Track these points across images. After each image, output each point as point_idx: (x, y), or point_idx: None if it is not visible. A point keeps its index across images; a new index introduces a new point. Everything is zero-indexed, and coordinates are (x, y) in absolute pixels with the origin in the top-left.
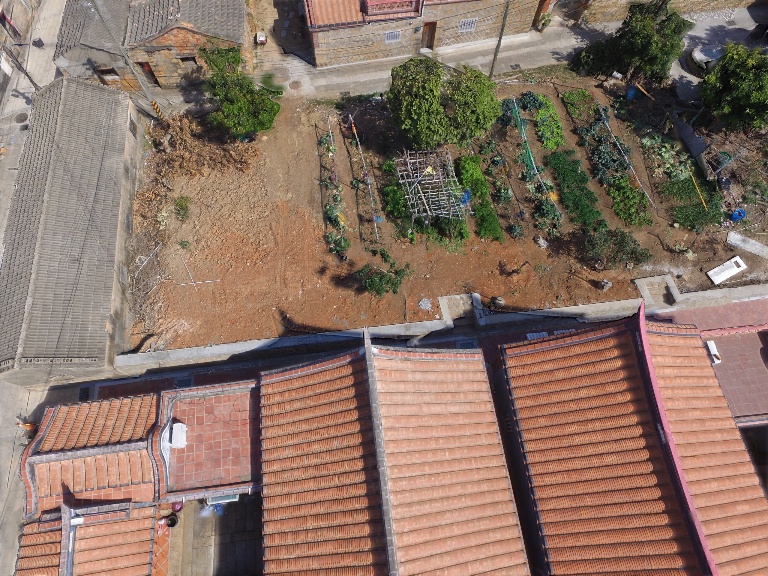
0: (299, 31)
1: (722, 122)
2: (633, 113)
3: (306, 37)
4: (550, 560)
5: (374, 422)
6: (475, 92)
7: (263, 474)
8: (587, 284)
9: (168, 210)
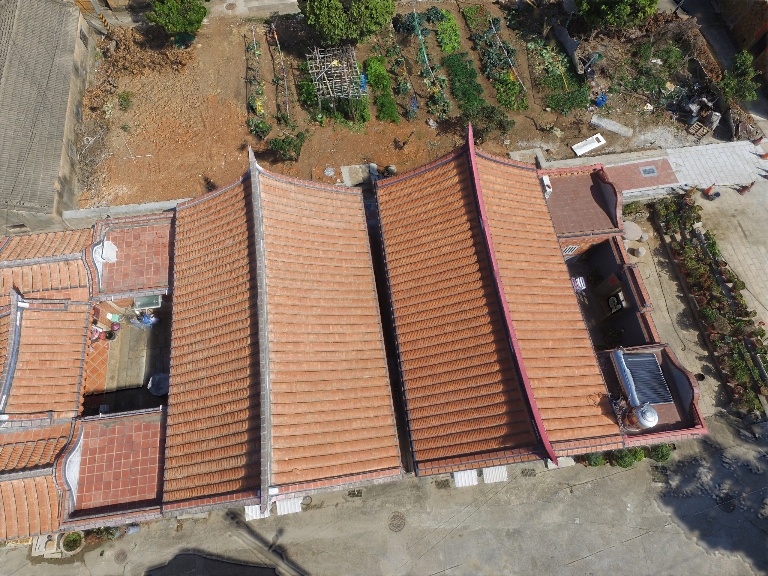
0: None
1: (588, 21)
2: (523, 23)
3: None
4: (397, 325)
5: (254, 215)
6: None
7: (174, 272)
8: None
9: (113, 102)
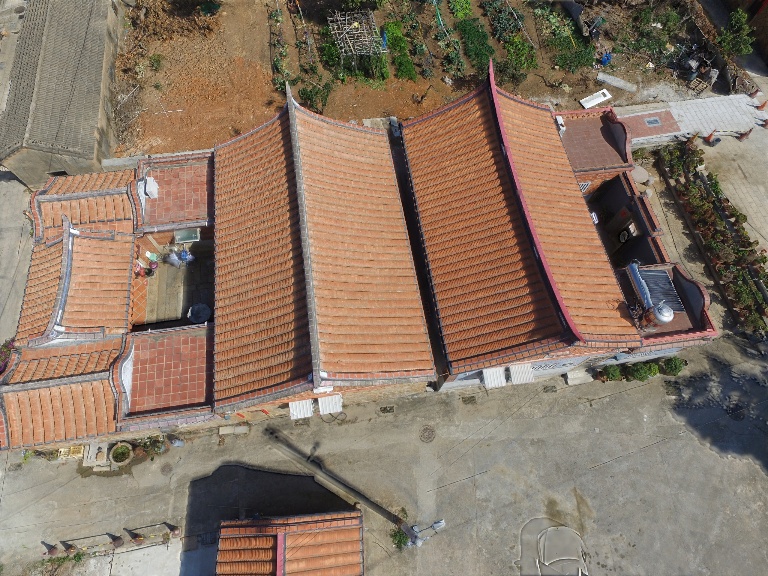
0: None
1: None
2: None
3: None
4: (426, 245)
5: (293, 143)
6: None
7: (215, 203)
8: None
9: (144, 64)
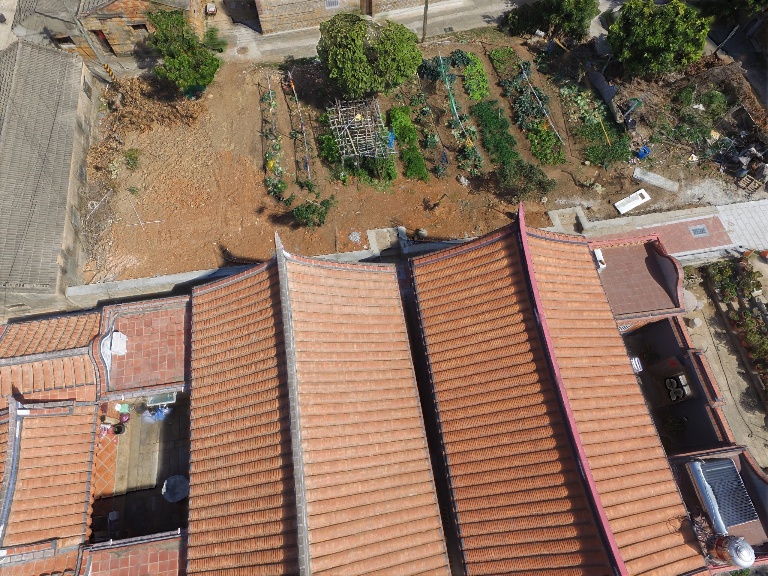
0: (248, 2)
1: (627, 68)
2: (554, 67)
3: (254, 8)
4: (443, 431)
5: (283, 312)
6: (394, 41)
7: (192, 370)
8: (504, 216)
9: (119, 161)
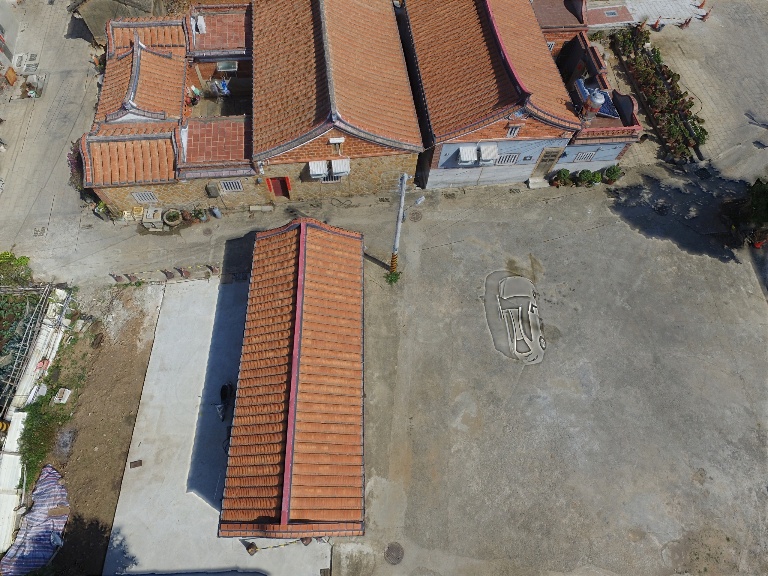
0: None
1: None
2: None
3: None
4: None
5: None
6: None
7: (253, 32)
8: None
9: None
